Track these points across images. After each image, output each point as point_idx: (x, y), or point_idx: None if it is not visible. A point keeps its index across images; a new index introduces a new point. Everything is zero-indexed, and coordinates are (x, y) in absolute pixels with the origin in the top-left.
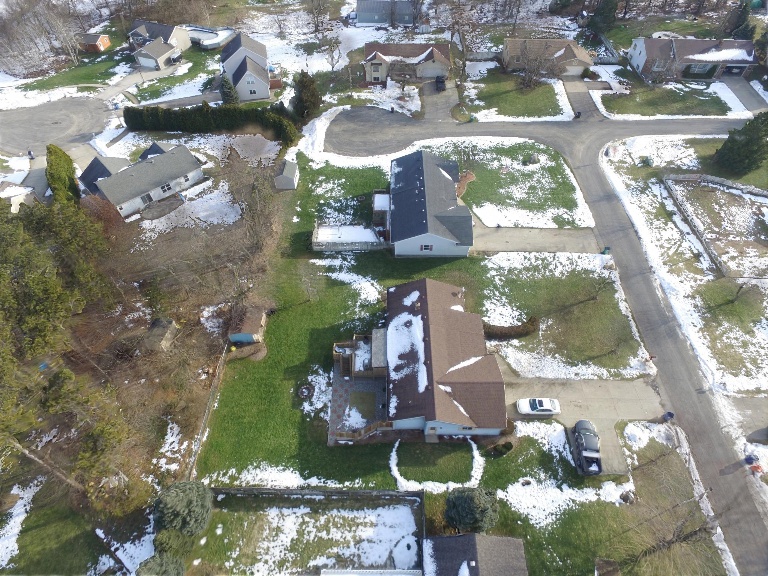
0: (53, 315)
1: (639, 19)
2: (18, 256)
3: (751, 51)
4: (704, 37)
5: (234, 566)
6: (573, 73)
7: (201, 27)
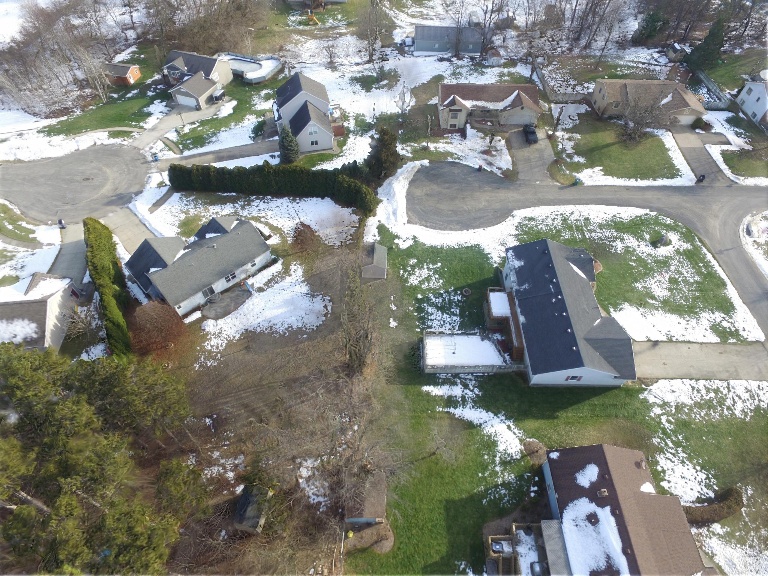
0: (144, 570)
1: (736, 52)
2: (87, 465)
3: None
4: None
5: None
6: (682, 122)
7: (242, 56)
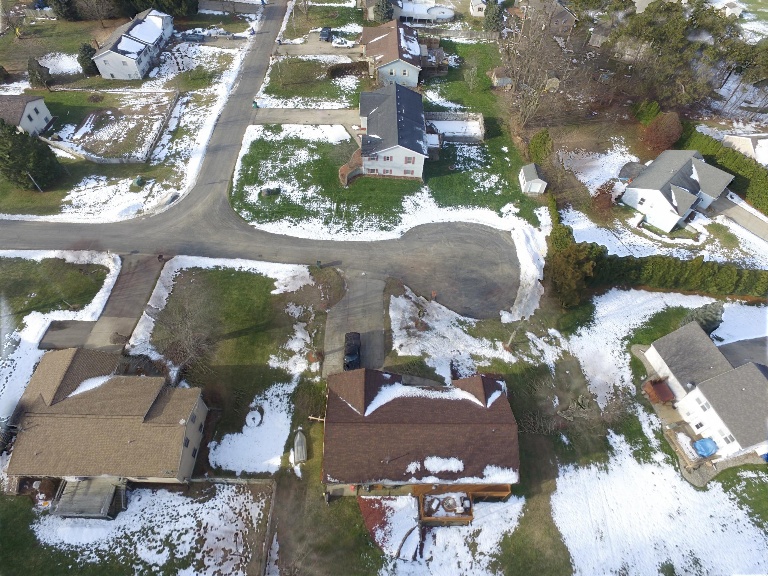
0: None
1: None
2: None
3: None
4: None
5: None
6: None
7: None
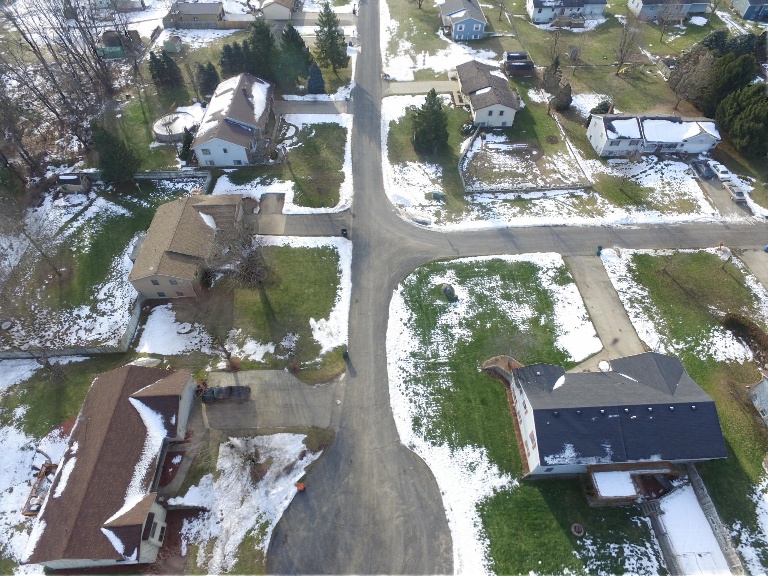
0: None
1: None
2: None
3: (258, 80)
4: (191, 100)
5: None
6: None
7: None
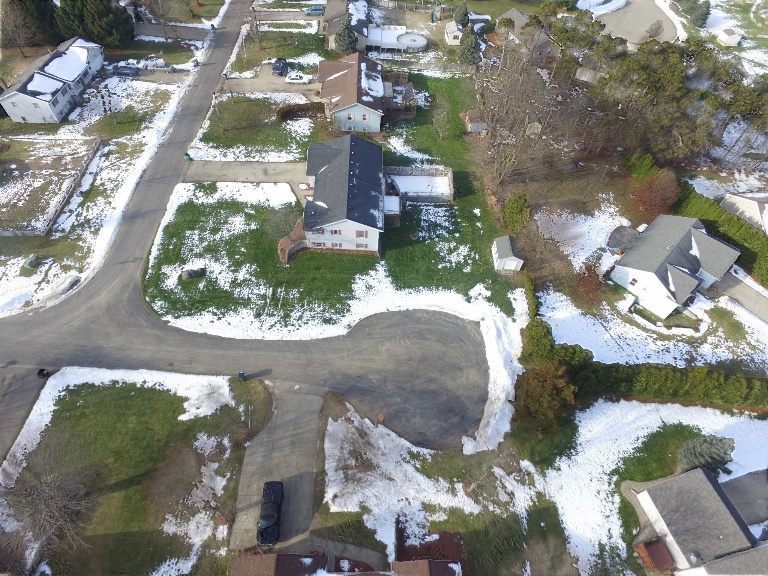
0: None
1: None
2: None
3: None
4: None
5: (443, 57)
6: None
7: None
